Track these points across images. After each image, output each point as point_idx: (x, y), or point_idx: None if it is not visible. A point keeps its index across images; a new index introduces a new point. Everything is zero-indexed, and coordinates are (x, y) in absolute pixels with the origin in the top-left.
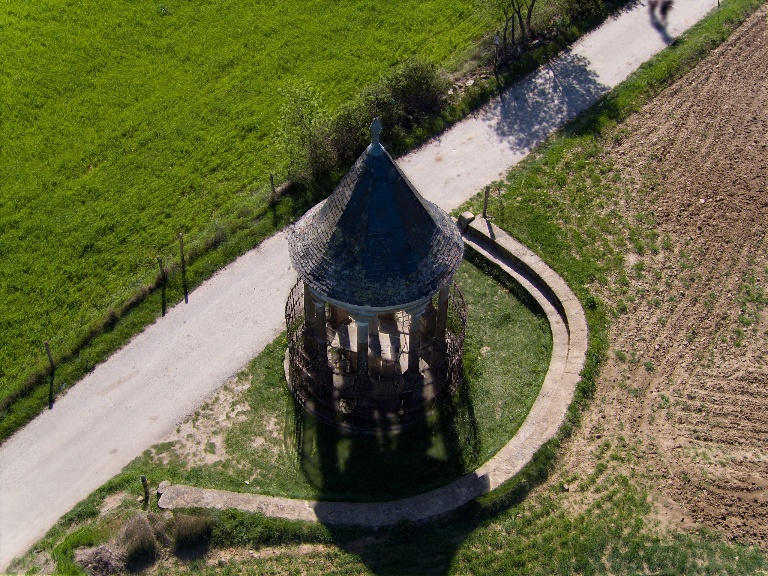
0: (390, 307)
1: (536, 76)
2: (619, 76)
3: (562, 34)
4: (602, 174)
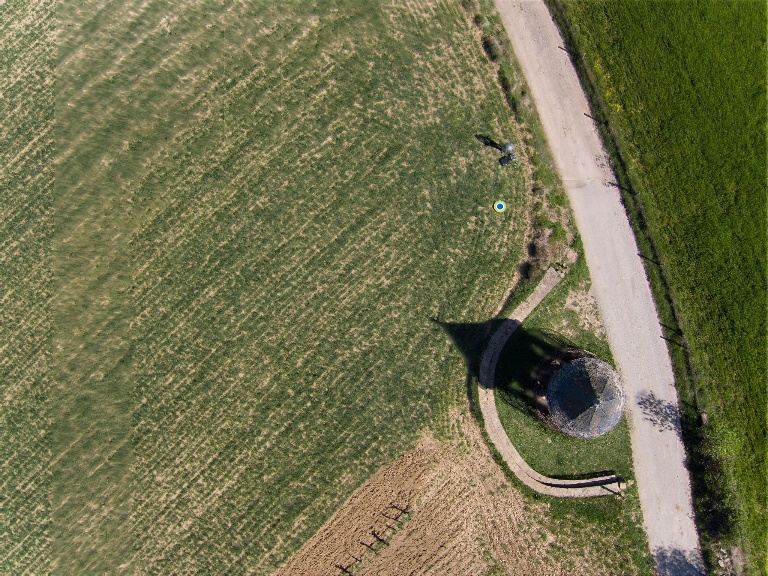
0: None
1: None
2: None
3: None
4: (611, 572)
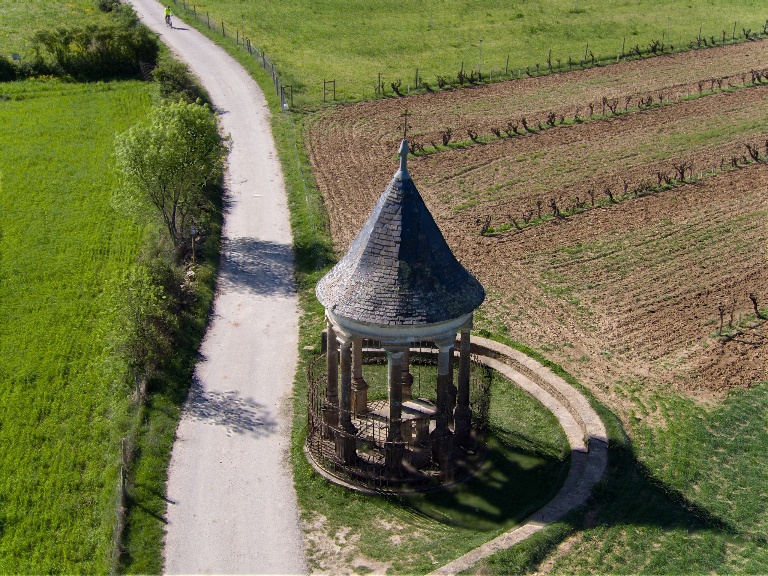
0: (465, 319)
1: (227, 258)
2: (286, 237)
3: (210, 229)
4: None
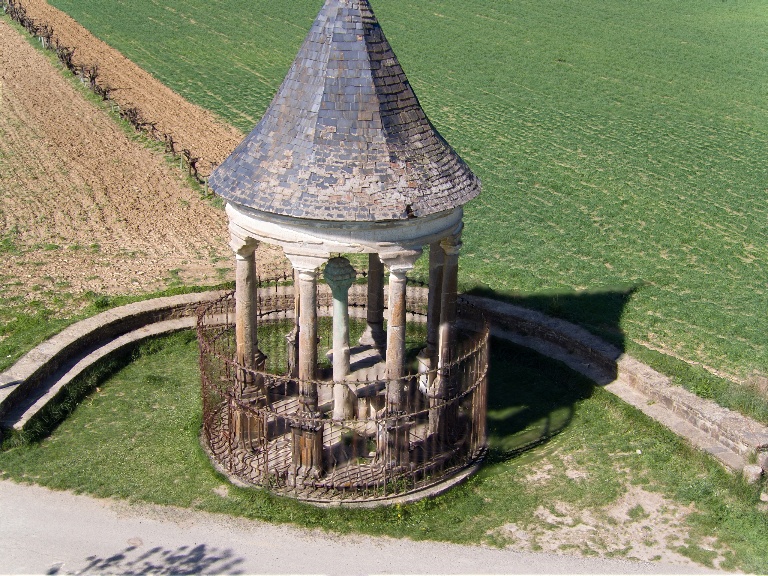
0: None
1: None
2: None
3: None
4: None
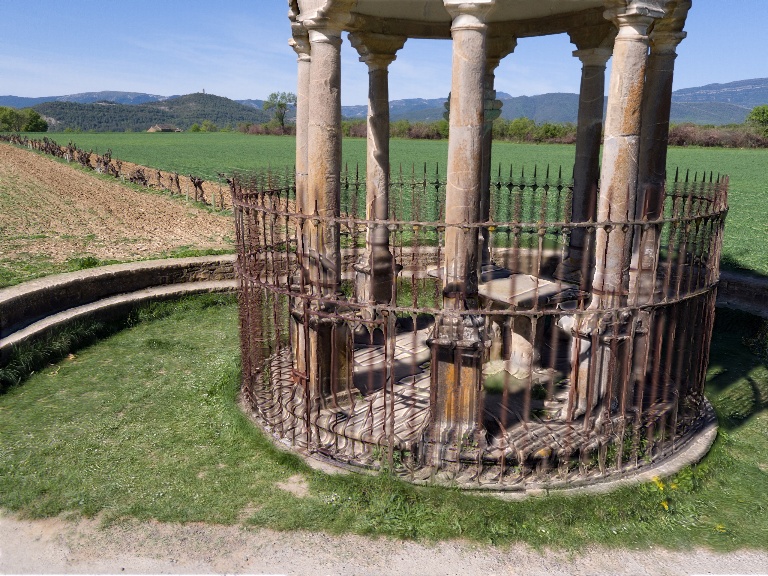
0: None
1: None
2: None
3: None
4: None
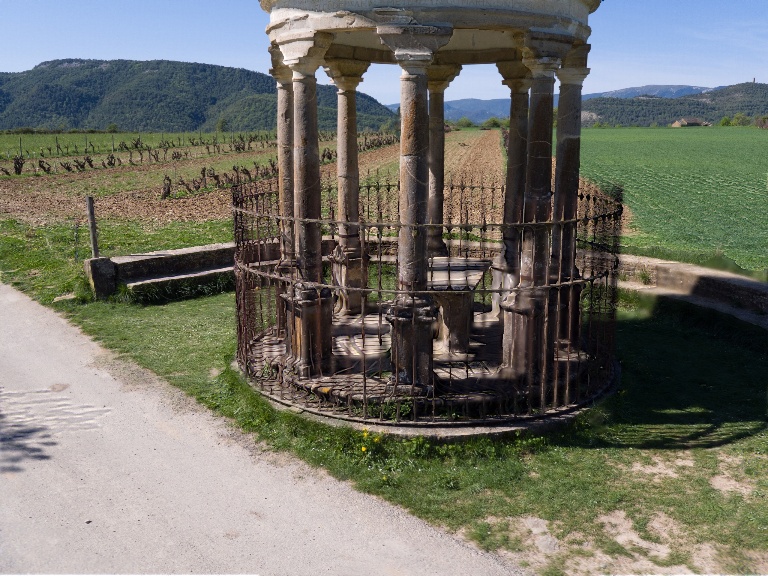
0: None
1: None
2: None
3: None
4: None
